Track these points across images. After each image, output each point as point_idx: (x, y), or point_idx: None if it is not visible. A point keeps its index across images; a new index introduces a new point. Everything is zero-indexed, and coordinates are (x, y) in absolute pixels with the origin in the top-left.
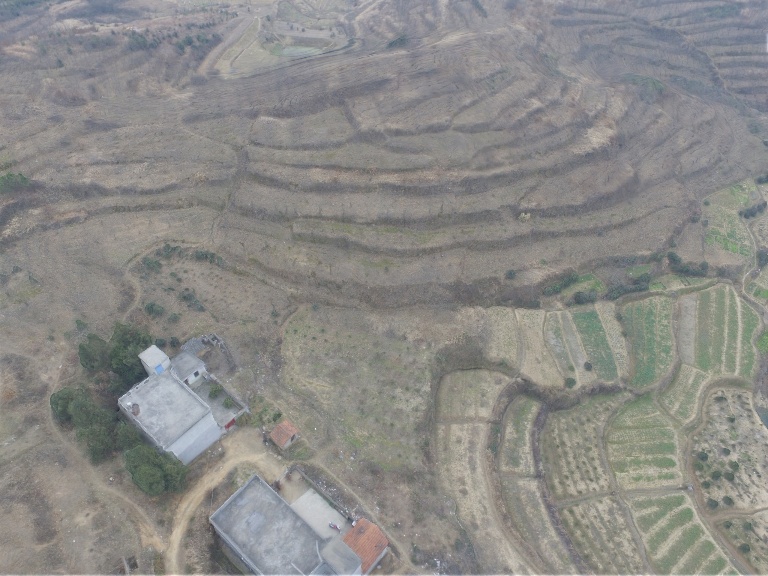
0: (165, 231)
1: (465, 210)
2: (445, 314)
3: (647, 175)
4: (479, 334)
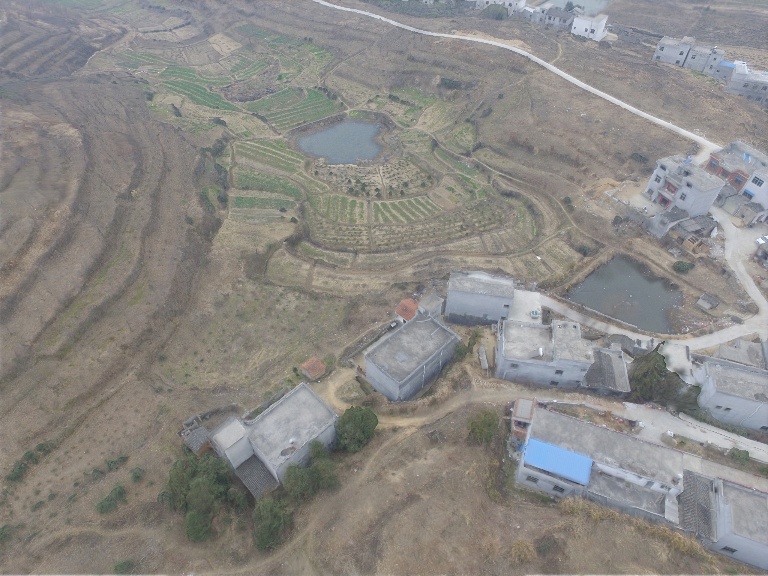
0: None
1: (108, 220)
2: (211, 268)
3: (120, 131)
4: (240, 252)
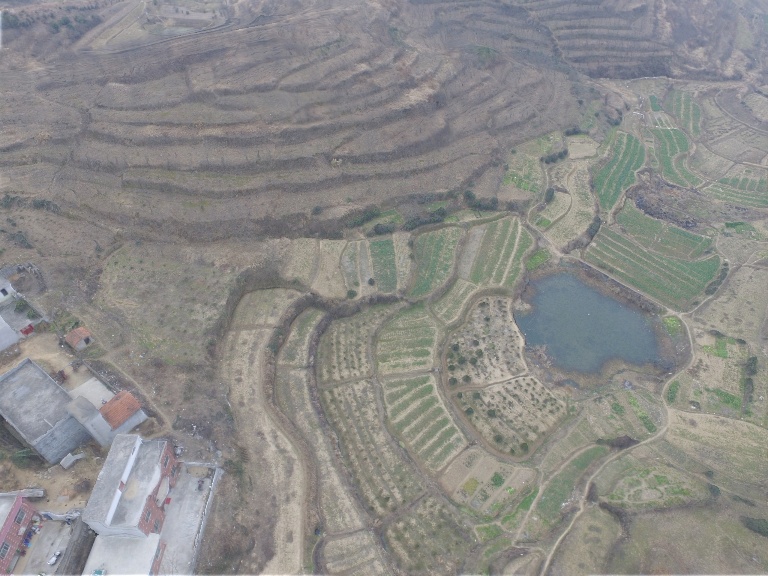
0: (7, 184)
1: (282, 157)
2: (254, 245)
3: (460, 128)
4: (280, 259)
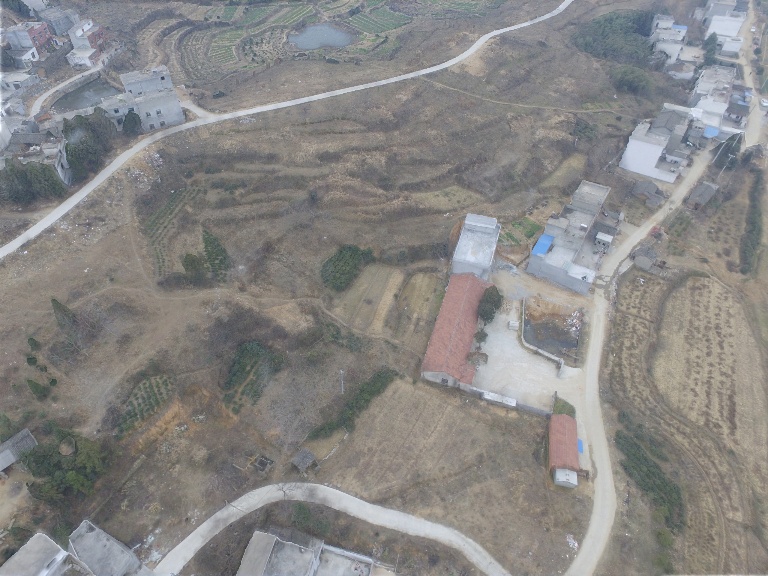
0: None
1: None
2: None
3: None
4: (175, 7)
